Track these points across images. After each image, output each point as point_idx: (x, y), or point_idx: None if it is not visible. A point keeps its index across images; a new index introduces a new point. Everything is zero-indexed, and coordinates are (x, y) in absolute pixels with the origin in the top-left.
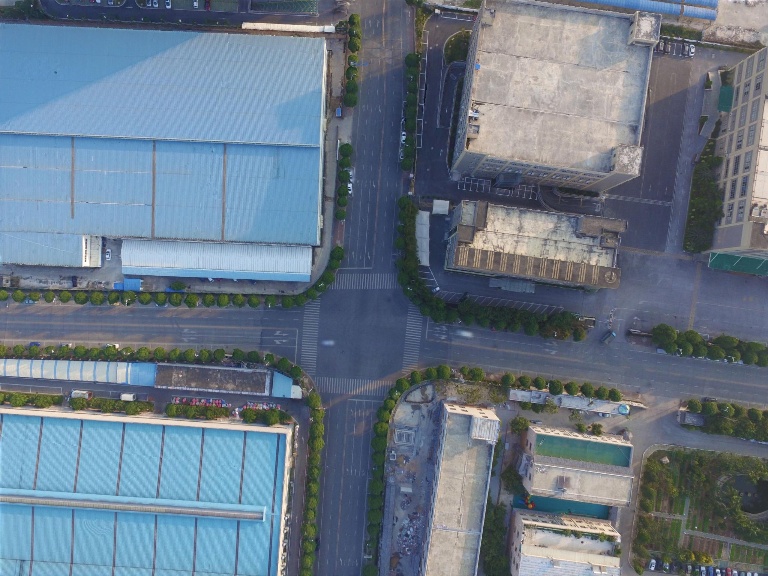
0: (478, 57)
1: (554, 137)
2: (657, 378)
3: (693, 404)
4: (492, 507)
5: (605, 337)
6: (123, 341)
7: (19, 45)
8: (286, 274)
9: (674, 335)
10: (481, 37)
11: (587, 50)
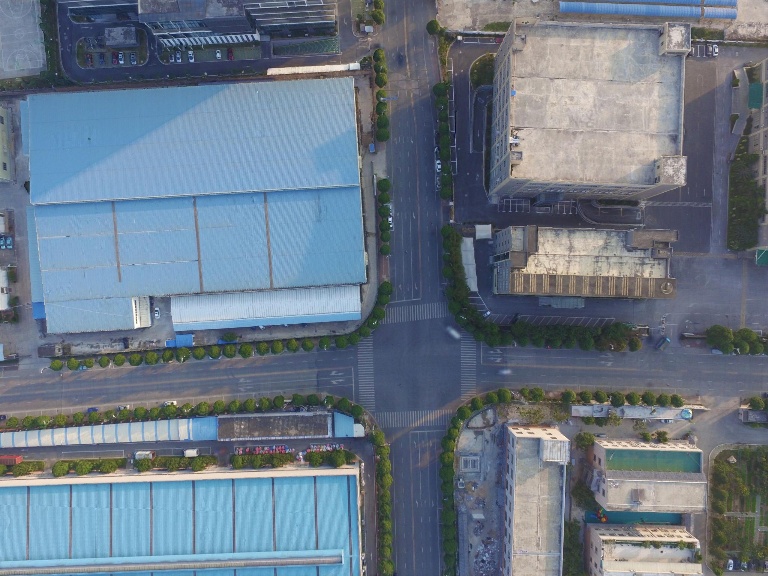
0: (512, 83)
1: (596, 155)
2: (715, 379)
3: (755, 402)
4: (566, 525)
5: (659, 344)
6: (180, 397)
7: (50, 115)
8: (337, 314)
9: (731, 336)
10: (513, 63)
11: (619, 65)
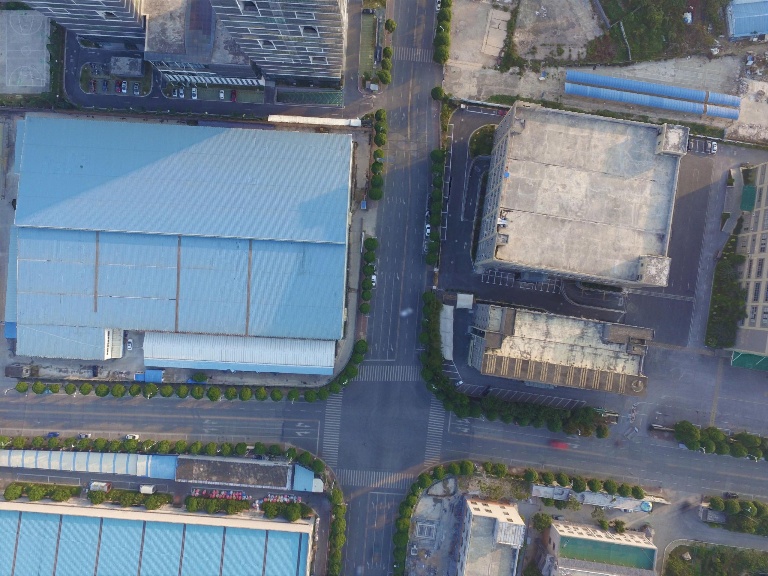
0: (507, 165)
1: (582, 245)
2: (679, 473)
3: (716, 503)
4: None
5: (627, 432)
6: (143, 432)
7: (45, 138)
8: (309, 367)
9: (698, 436)
10: (510, 145)
11: (615, 159)
